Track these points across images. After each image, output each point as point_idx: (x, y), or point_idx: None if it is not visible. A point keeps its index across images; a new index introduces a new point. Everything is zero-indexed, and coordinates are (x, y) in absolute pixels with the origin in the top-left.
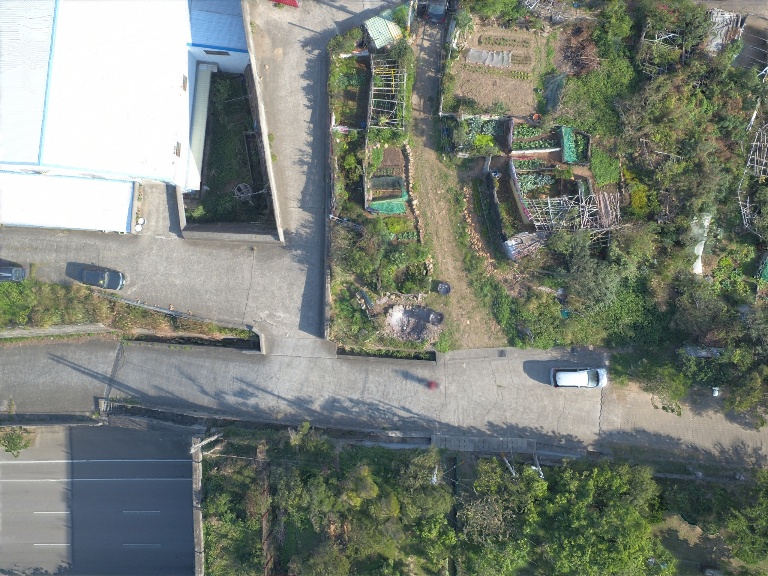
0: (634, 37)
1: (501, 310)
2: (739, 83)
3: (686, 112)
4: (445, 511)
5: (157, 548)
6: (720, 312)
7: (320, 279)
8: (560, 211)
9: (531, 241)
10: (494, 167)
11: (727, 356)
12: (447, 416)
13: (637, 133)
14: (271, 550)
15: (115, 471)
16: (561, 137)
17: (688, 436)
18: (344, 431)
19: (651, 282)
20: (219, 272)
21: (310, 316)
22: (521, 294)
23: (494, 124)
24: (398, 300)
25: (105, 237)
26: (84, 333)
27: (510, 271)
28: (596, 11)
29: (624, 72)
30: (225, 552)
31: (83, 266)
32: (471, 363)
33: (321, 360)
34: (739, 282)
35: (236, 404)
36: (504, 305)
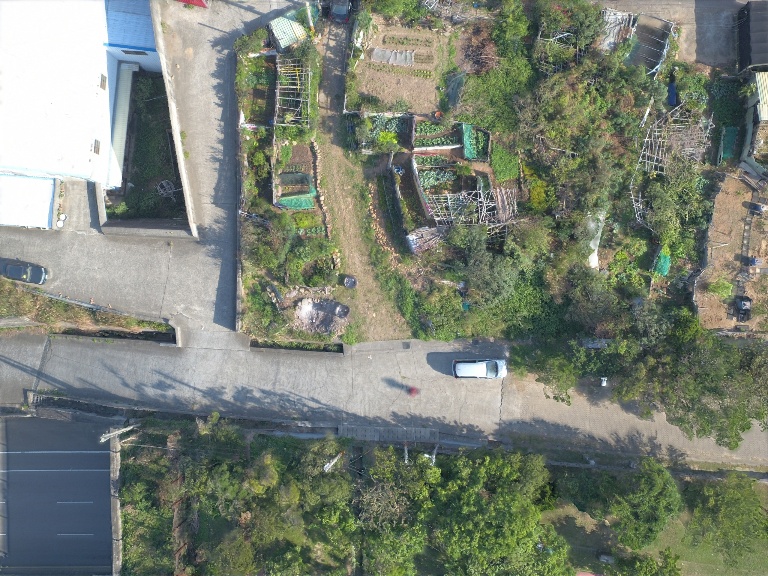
0: (533, 36)
1: (405, 303)
2: (630, 81)
3: (581, 109)
4: (351, 499)
5: (90, 538)
6: (611, 304)
7: (233, 273)
8: (459, 206)
9: (431, 235)
10: (398, 163)
11: (614, 347)
12: (354, 407)
13: (533, 130)
14: (185, 537)
15: (49, 462)
16: (462, 134)
17: (585, 426)
18: (257, 422)
19: (546, 275)
20: (137, 267)
21: (224, 309)
22: (424, 287)
23: (397, 121)
24: (307, 293)
25: (29, 233)
26: (14, 327)
27: (414, 265)
28: (495, 11)
29: (522, 70)
30: (141, 540)
31: (8, 261)
32: (377, 355)
33: (235, 352)
34: (634, 275)
35: (155, 395)
36: (408, 298)
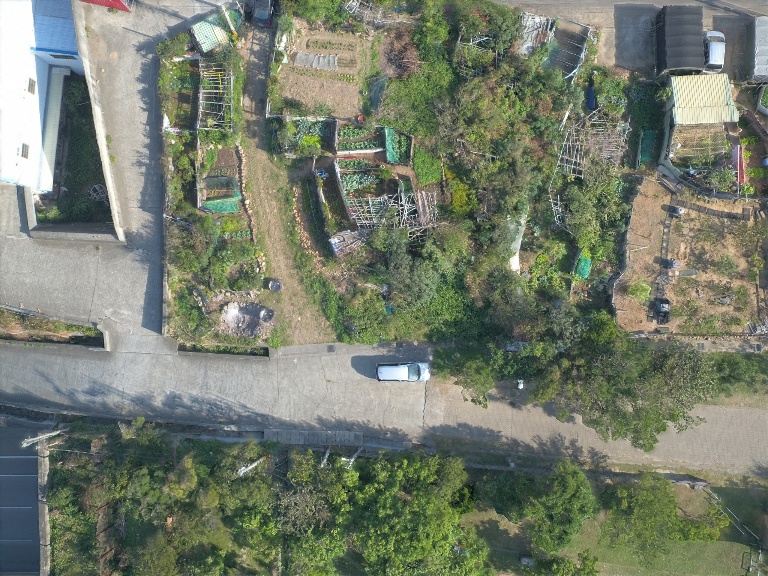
0: (454, 40)
1: (329, 306)
2: (547, 85)
3: (500, 113)
4: None
5: (28, 543)
6: (529, 307)
7: (161, 277)
8: (381, 210)
9: (353, 239)
10: (322, 167)
11: (530, 350)
12: (279, 410)
13: (453, 134)
14: (112, 542)
15: None
16: (385, 138)
17: (508, 428)
18: (184, 426)
19: (467, 278)
20: (66, 271)
21: (152, 313)
22: (348, 291)
23: (321, 125)
24: (233, 297)
25: None
26: None
27: (338, 268)
28: (417, 15)
29: (443, 74)
30: (69, 545)
31: None
32: (302, 358)
33: (163, 356)
34: (555, 278)
35: (84, 400)
36: (332, 302)
